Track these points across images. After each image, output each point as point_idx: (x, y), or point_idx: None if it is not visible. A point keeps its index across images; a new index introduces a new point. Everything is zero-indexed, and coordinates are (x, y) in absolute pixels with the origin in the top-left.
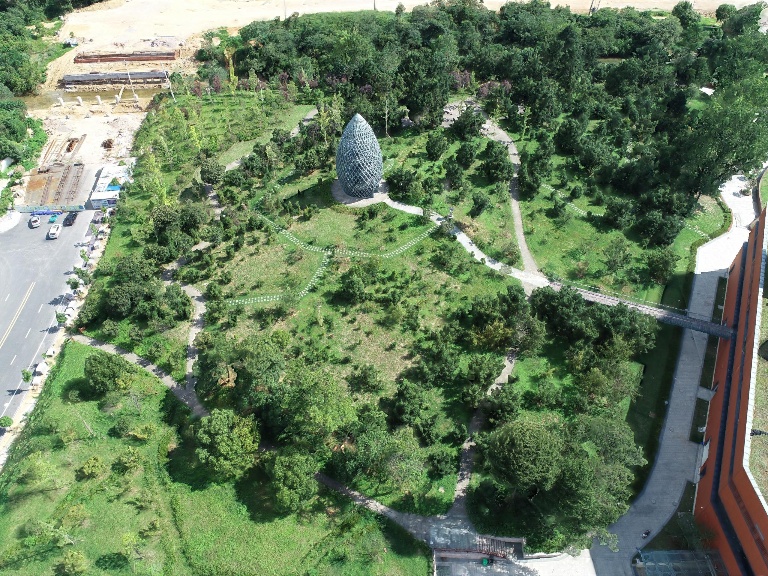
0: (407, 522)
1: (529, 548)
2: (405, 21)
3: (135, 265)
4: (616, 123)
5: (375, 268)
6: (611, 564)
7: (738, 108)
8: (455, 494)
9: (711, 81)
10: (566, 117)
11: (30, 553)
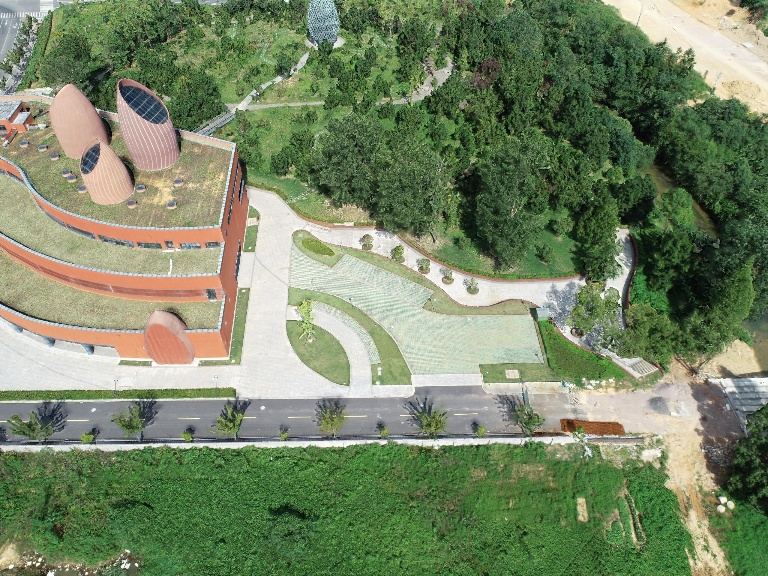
0: (100, 77)
1: None
2: (607, 37)
3: None
4: None
5: None
6: None
7: (358, 129)
8: None
9: (638, 270)
10: None
11: (115, 6)
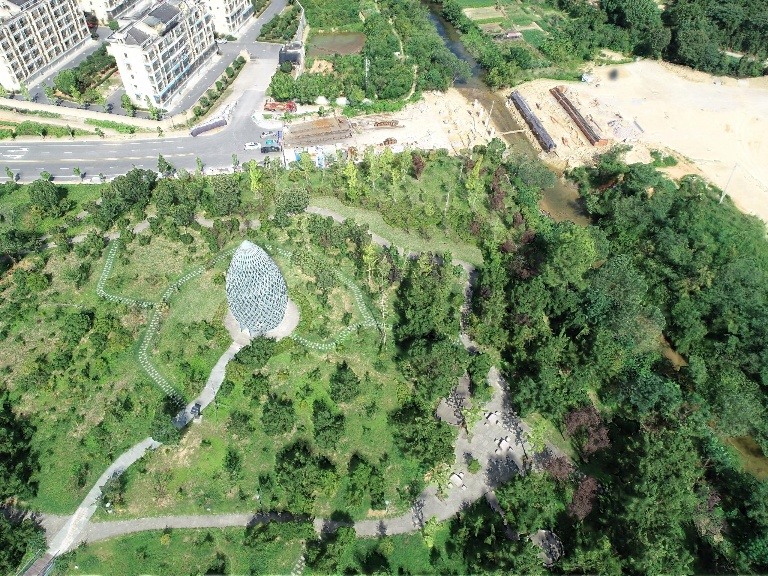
0: None
1: None
2: None
3: (135, 176)
4: None
5: (108, 341)
6: None
7: None
8: None
9: None
10: None
11: None
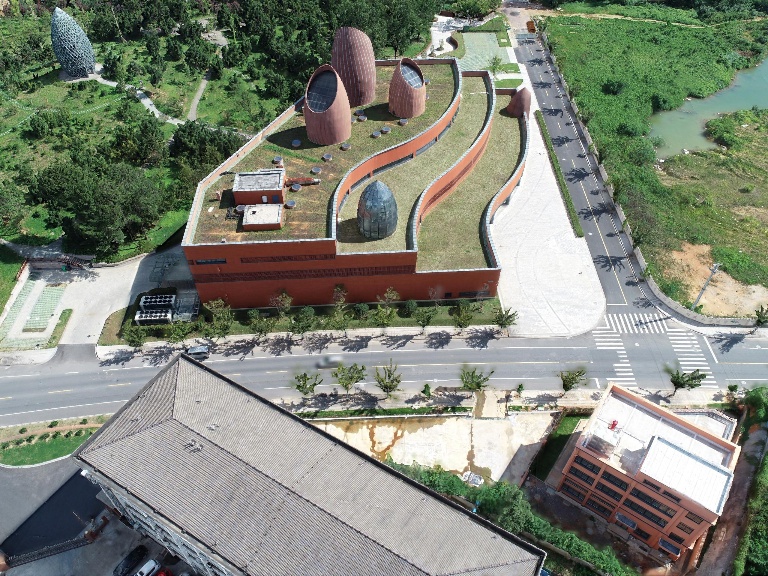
0: (18, 248)
1: (94, 259)
2: None
3: None
4: (314, 30)
5: (63, 116)
6: (150, 269)
7: None
8: (60, 236)
9: None
10: (282, 28)
11: None
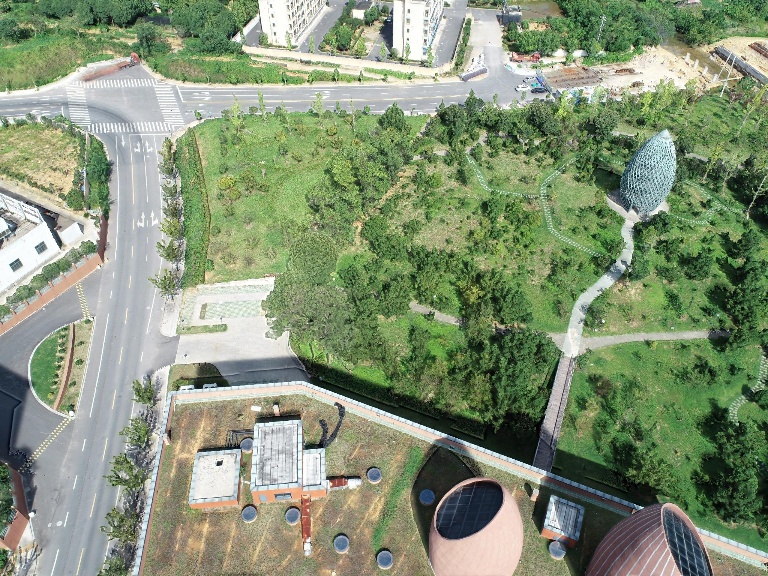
0: None
1: None
2: None
3: (473, 103)
4: None
5: (526, 219)
6: (282, 380)
7: None
8: None
9: None
10: None
11: None
